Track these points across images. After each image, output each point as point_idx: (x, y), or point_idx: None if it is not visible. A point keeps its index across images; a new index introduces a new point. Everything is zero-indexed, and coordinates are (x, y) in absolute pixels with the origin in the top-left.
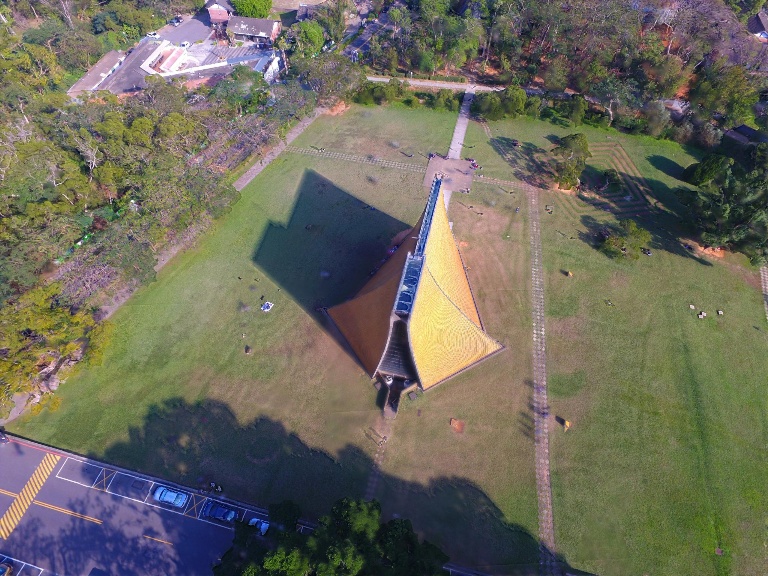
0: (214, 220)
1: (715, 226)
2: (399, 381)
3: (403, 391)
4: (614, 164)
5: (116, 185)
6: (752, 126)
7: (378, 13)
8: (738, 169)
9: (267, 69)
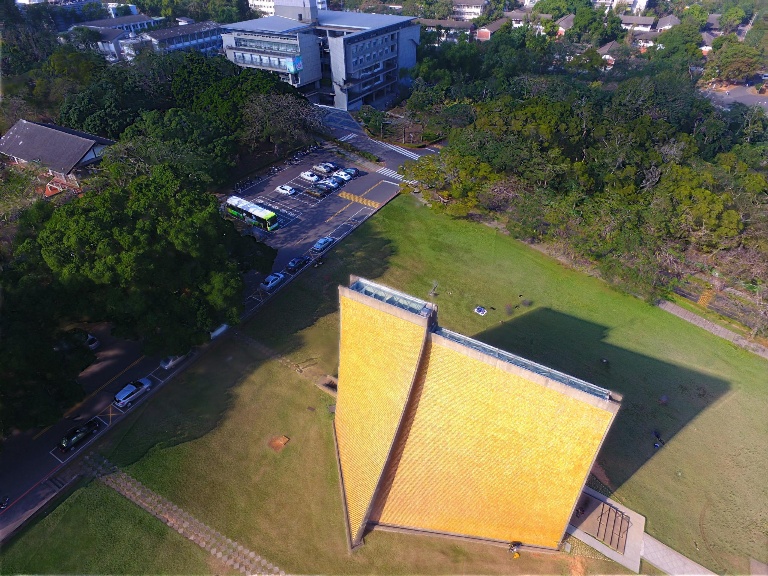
0: (609, 286)
1: None
2: None
3: None
4: None
5: None
6: None
7: None
8: None
9: None
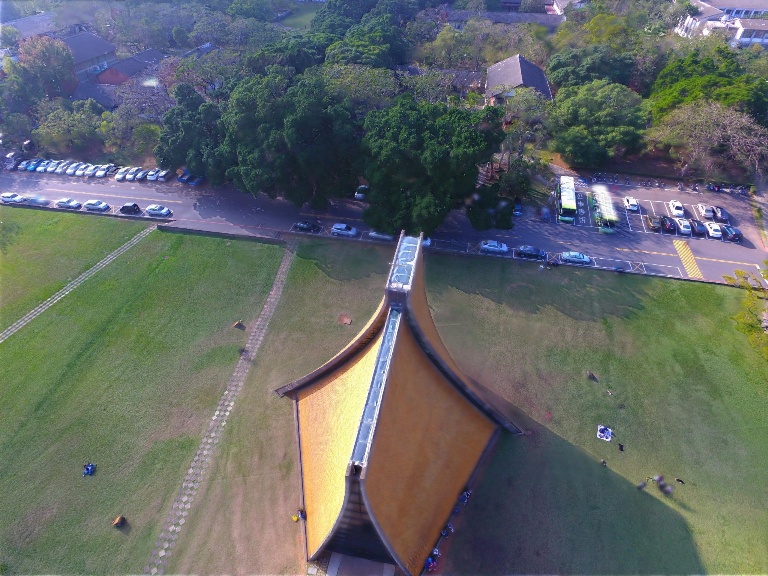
0: None
1: None
2: None
3: None
4: None
5: None
6: None
7: None
8: None
9: None
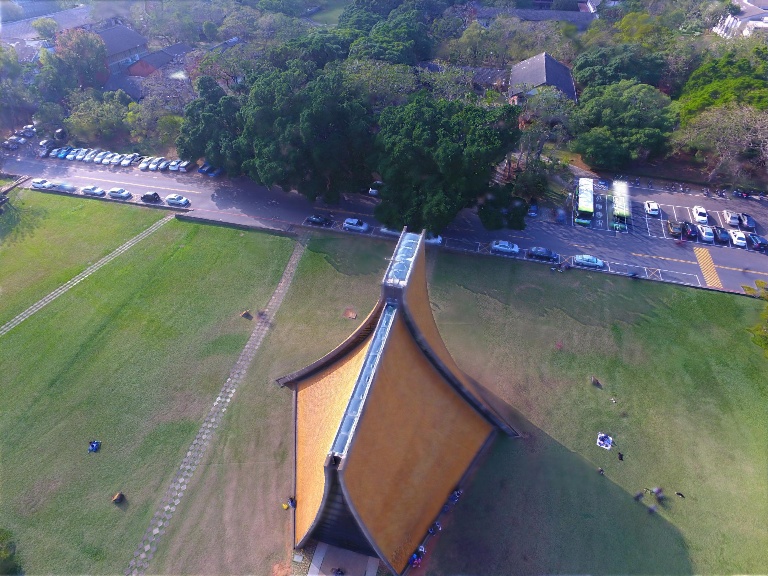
0: None
1: None
2: None
3: None
4: None
5: None
6: None
7: None
8: None
9: None
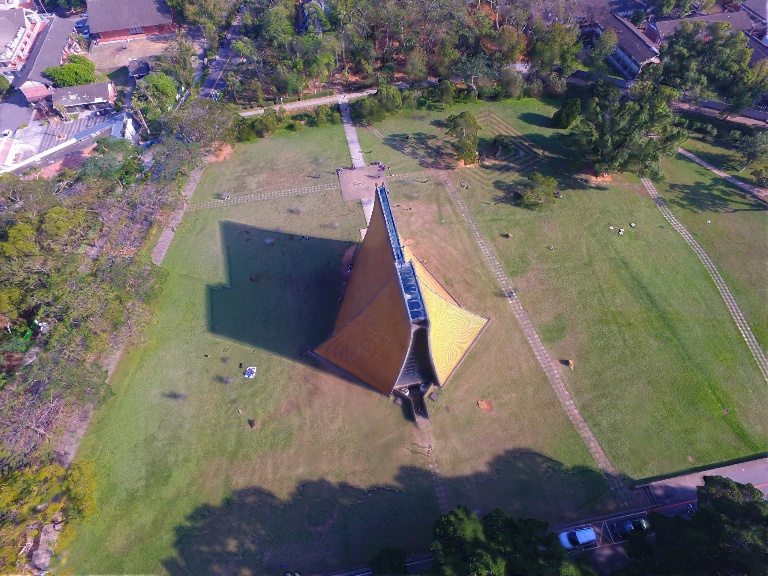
0: None
1: (600, 156)
2: (413, 389)
3: (425, 396)
4: (496, 130)
5: (16, 309)
6: (580, 69)
7: (216, 50)
8: (602, 105)
9: (124, 134)
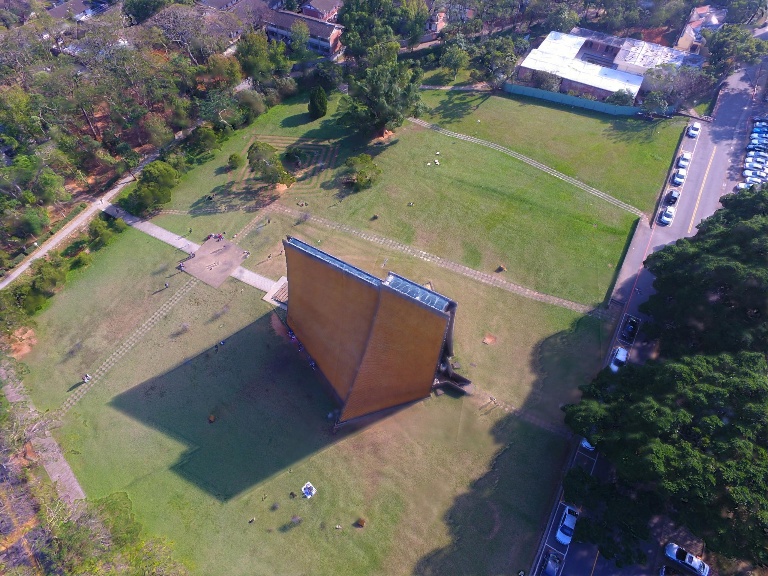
0: None
1: (378, 119)
2: None
3: (452, 371)
4: (276, 147)
5: None
6: None
7: None
8: None
9: None
